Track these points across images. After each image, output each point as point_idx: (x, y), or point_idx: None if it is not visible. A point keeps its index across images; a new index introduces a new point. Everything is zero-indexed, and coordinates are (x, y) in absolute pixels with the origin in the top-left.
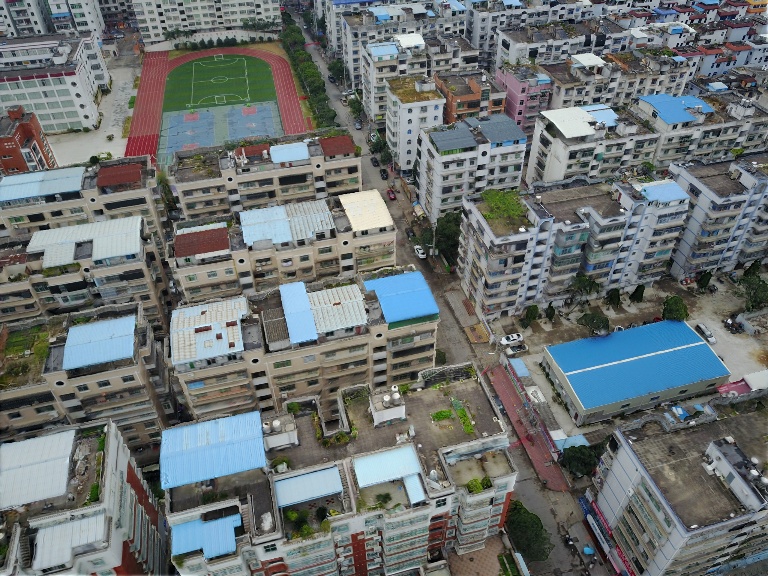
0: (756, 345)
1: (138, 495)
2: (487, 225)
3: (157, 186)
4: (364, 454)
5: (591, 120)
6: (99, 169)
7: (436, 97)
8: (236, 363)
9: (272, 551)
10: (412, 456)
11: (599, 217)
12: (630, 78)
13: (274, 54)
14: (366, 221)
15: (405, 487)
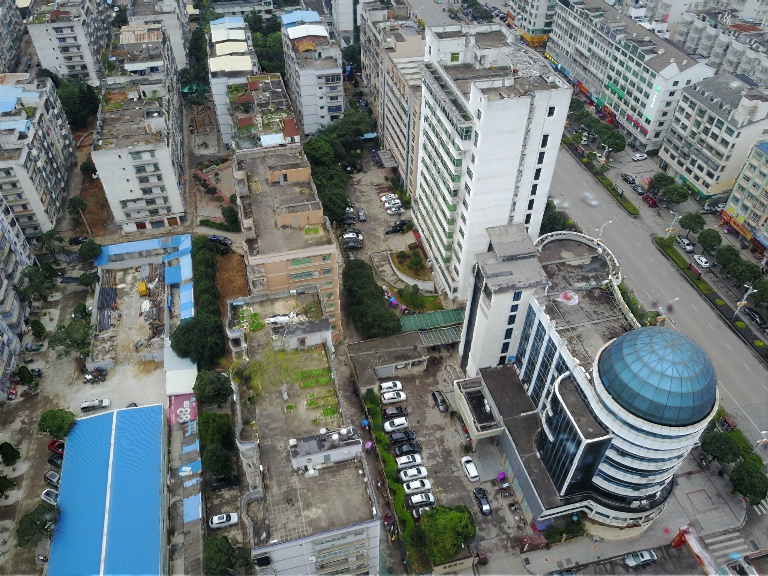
0: (127, 368)
1: None
2: None
3: None
4: None
5: None
6: None
7: None
8: None
9: None
10: None
11: None
12: None
13: None
14: None
15: None
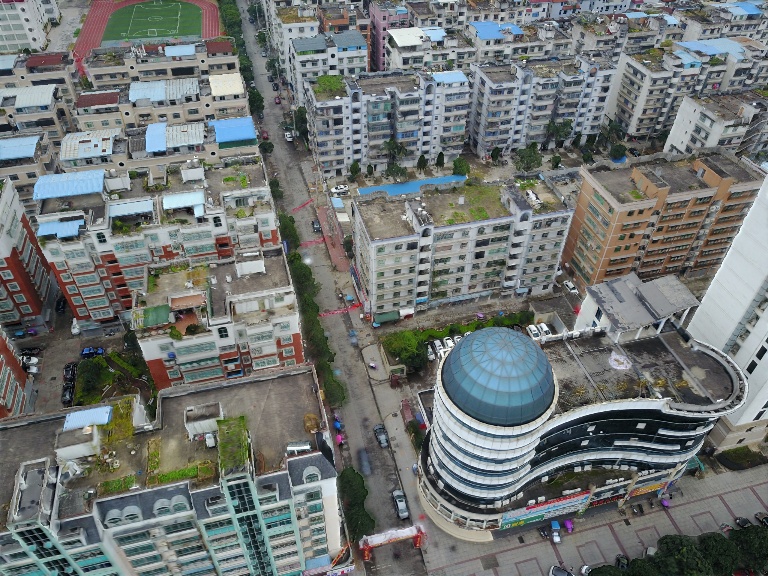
0: None
1: (31, 240)
2: (313, 95)
3: (76, 73)
4: (170, 193)
5: (422, 35)
6: (29, 57)
7: (312, 21)
8: (107, 164)
9: (104, 243)
10: (202, 196)
11: (399, 92)
12: (475, 13)
13: (207, 1)
14: (224, 90)
15: (194, 211)
